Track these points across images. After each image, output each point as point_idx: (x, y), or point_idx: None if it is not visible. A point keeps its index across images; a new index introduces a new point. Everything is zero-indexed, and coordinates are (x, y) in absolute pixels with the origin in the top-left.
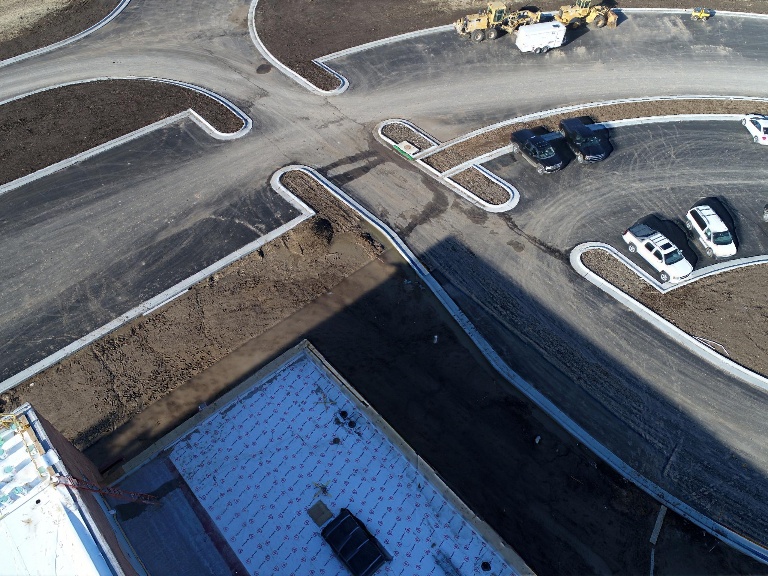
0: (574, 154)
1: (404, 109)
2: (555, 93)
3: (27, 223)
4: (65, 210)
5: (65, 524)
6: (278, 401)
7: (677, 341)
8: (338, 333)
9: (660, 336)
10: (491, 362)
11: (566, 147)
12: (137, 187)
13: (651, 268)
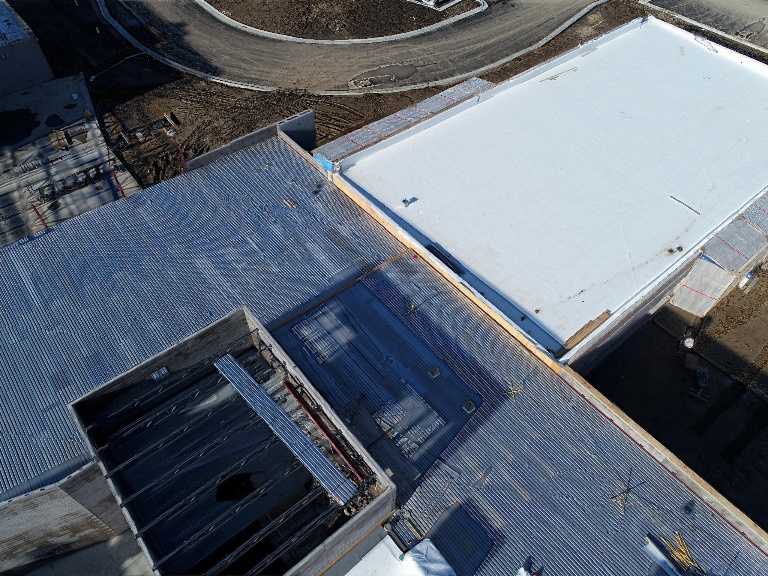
0: None
1: None
2: None
3: None
4: None
5: None
6: None
7: (210, 12)
8: (28, 1)
9: (202, 10)
10: (102, 13)
11: None
12: None
13: None
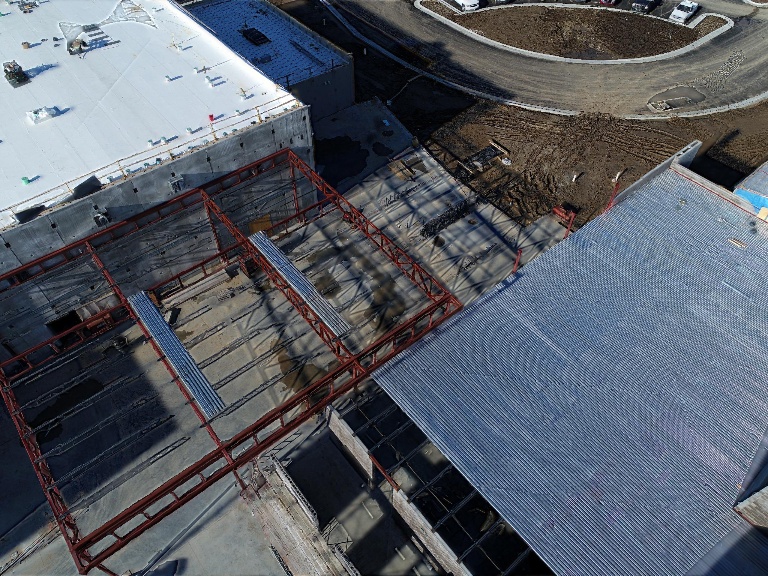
0: None
1: None
2: None
3: None
4: None
5: None
6: (231, 6)
7: (459, 31)
8: None
9: (451, 29)
10: (353, 32)
11: None
12: None
13: (459, 6)
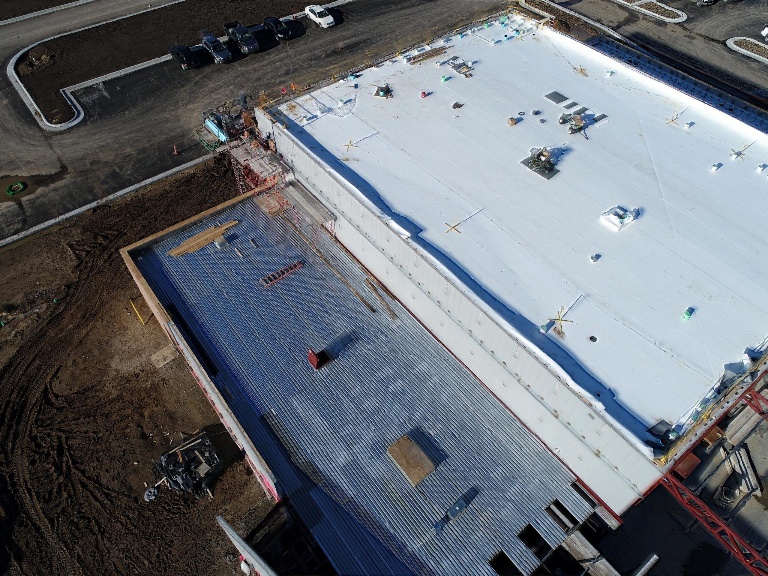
0: None
1: None
2: None
3: (376, 14)
4: (396, 10)
5: (551, 39)
6: None
7: None
8: None
9: None
10: None
11: None
12: (435, 2)
13: None
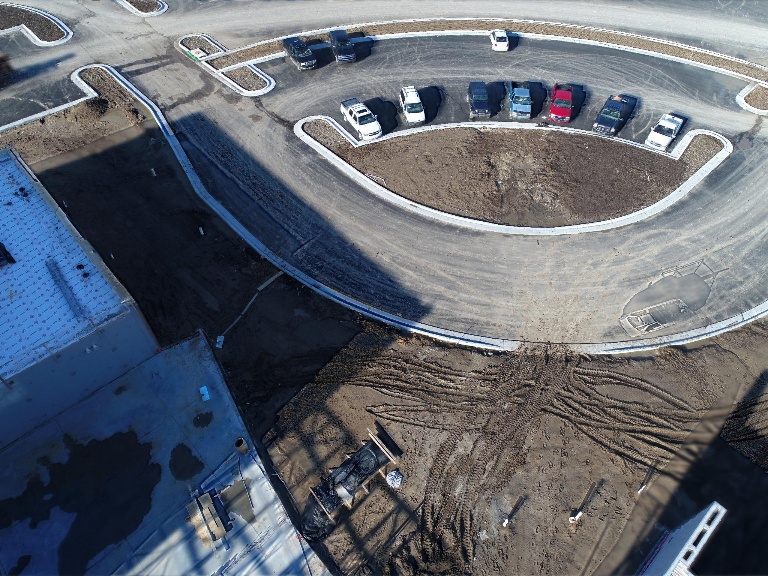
0: (335, 57)
1: (208, 26)
2: (342, 16)
3: None
4: None
5: None
6: None
7: (351, 177)
8: (80, 170)
9: (339, 174)
10: (194, 188)
11: (332, 53)
12: None
13: (355, 131)
